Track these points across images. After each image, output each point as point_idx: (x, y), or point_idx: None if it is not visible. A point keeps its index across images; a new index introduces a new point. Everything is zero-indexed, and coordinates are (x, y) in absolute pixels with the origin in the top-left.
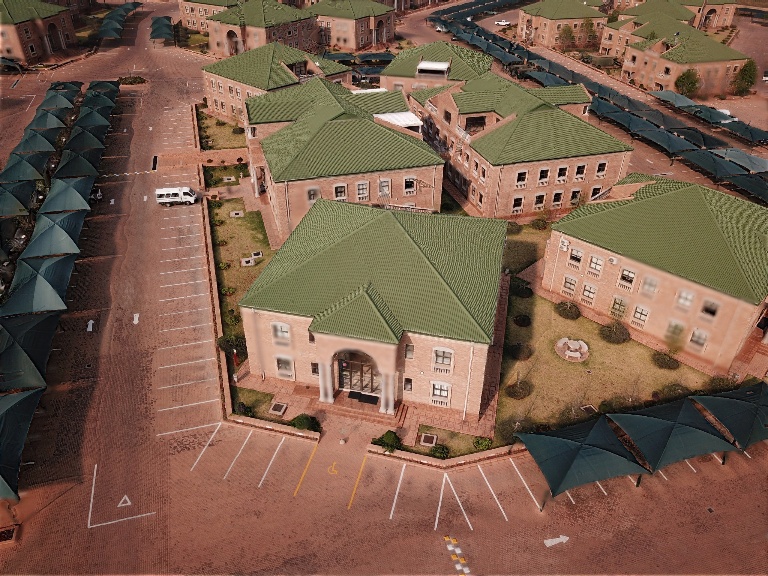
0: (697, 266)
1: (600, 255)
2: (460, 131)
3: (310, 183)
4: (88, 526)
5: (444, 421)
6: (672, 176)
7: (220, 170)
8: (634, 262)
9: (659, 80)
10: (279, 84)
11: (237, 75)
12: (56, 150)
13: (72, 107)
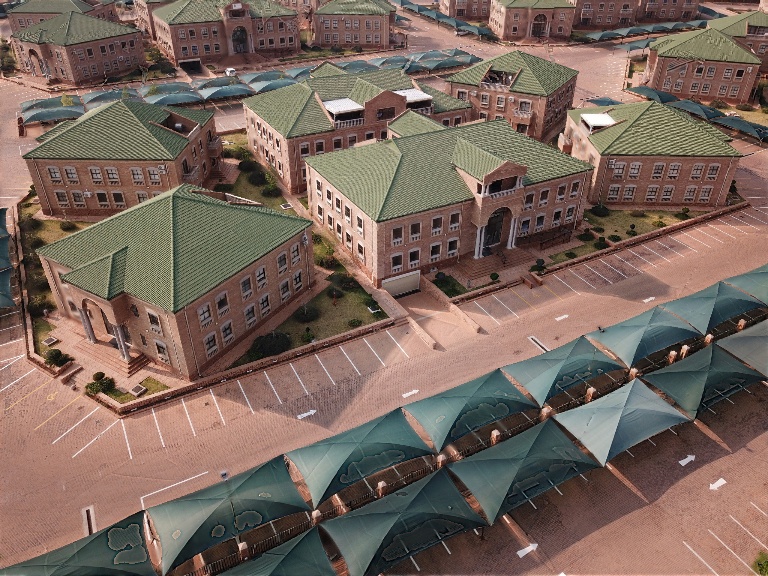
0: None
1: None
2: None
3: None
4: None
5: None
6: (539, 353)
7: None
8: None
9: None
10: (460, 80)
11: None
12: None
13: (415, 61)
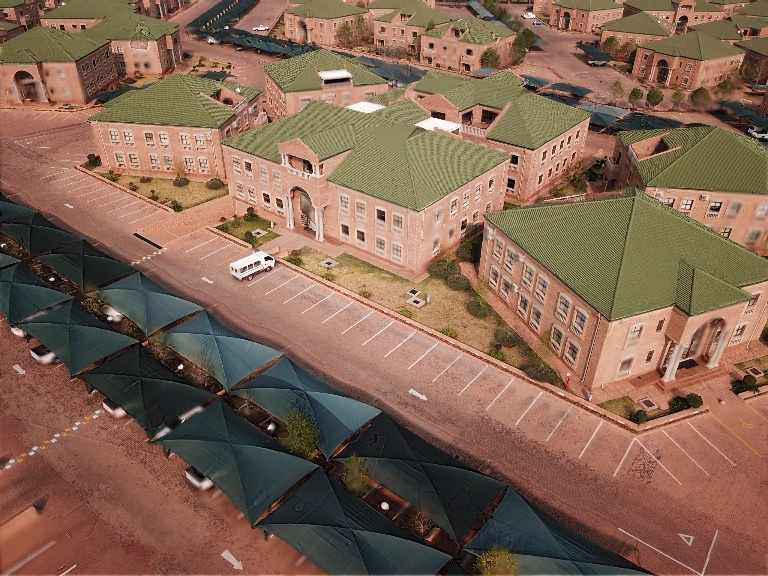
0: (767, 183)
1: (691, 196)
2: (465, 128)
3: (437, 204)
4: (701, 575)
5: (740, 355)
6: None
7: (234, 227)
8: (722, 194)
9: (465, 61)
10: (223, 119)
11: (158, 118)
12: (18, 260)
13: None
